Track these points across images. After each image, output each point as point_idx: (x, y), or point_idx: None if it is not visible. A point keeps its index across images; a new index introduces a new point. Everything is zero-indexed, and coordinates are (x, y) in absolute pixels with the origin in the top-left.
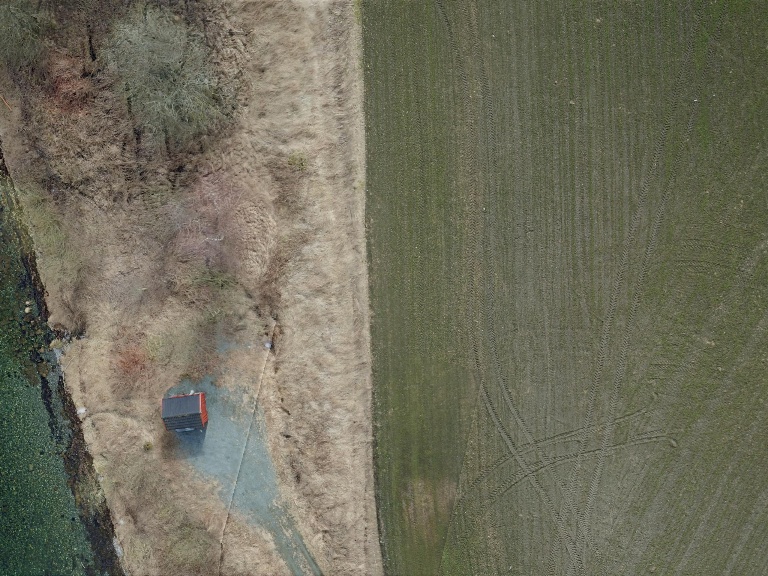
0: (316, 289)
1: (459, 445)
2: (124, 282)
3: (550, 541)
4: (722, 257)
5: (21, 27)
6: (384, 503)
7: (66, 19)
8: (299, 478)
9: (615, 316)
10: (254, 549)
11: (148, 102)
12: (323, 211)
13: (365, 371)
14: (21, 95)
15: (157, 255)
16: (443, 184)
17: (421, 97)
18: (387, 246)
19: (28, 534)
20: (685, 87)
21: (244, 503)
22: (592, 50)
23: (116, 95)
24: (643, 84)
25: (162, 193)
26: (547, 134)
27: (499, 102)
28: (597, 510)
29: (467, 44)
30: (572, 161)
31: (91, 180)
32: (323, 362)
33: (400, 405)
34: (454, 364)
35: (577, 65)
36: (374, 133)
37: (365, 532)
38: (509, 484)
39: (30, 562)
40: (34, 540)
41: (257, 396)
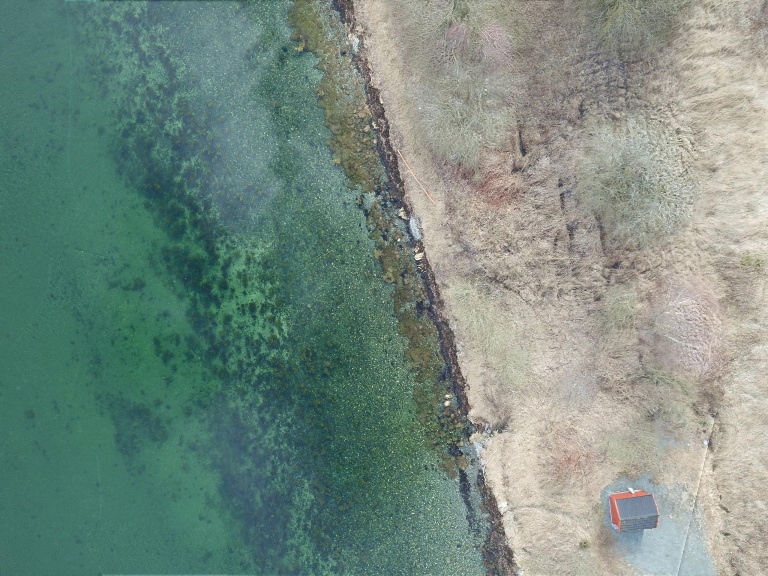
0: None
1: None
2: (552, 377)
3: None
4: None
5: (451, 122)
6: None
7: (495, 114)
8: None
9: None
10: None
11: (645, 212)
12: None
13: None
14: (445, 189)
15: (588, 351)
16: None
17: None
18: None
19: None
20: None
21: None
22: None
23: (549, 191)
24: None
25: (596, 289)
26: None
27: None
28: None
29: None
30: None
31: (518, 275)
32: None
33: None
34: None
35: None
36: None
37: None
38: None
39: None
40: None
41: (696, 494)
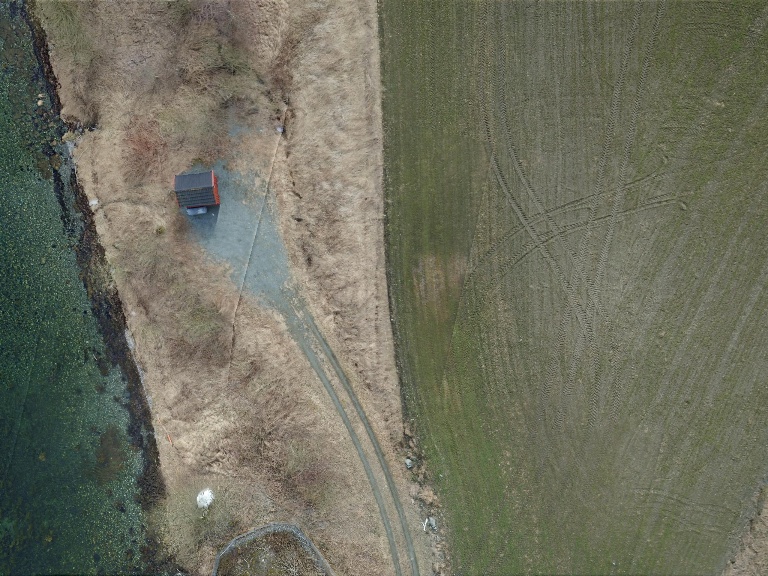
0: (328, 67)
1: (470, 219)
2: (136, 71)
3: (560, 311)
4: (732, 18)
5: None
6: (395, 280)
7: None
8: (310, 261)
9: (626, 81)
10: (266, 330)
11: None
12: None
13: (376, 147)
14: None
15: (169, 43)
16: None
17: None
18: (399, 20)
19: (40, 328)
20: None
21: (256, 285)
22: None
23: None
24: None
25: None
26: None
27: None
28: (607, 277)
29: None
30: None
31: None
32: (335, 140)
33: (411, 180)
34: (465, 137)
35: None
36: None
37: (376, 310)
38: (520, 255)
39: (42, 356)
40: (46, 333)
41: (269, 179)
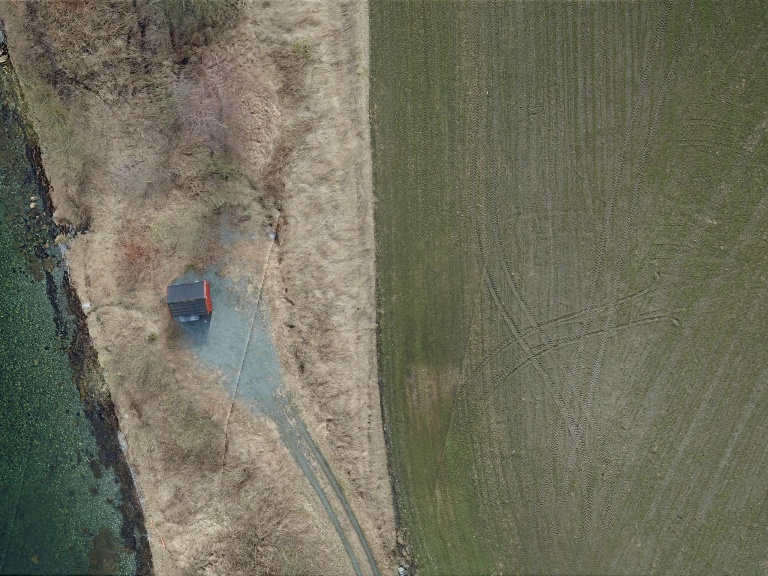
0: (320, 177)
1: (462, 330)
2: (129, 175)
3: (553, 424)
4: (724, 136)
5: None
6: (388, 390)
7: None
8: (303, 368)
9: (618, 197)
10: (258, 438)
11: None
12: (327, 98)
13: (369, 258)
14: None
15: (162, 148)
16: (446, 69)
17: None
18: (391, 132)
19: (33, 429)
20: None
21: (248, 392)
22: None
23: None
24: None
25: (167, 85)
26: (550, 16)
27: None
28: (600, 391)
29: None
30: (575, 43)
31: (96, 74)
32: (327, 250)
33: (404, 291)
34: (457, 249)
35: None
36: (378, 19)
37: (369, 419)
38: (512, 368)
39: (35, 457)
40: (39, 435)
41: (261, 286)
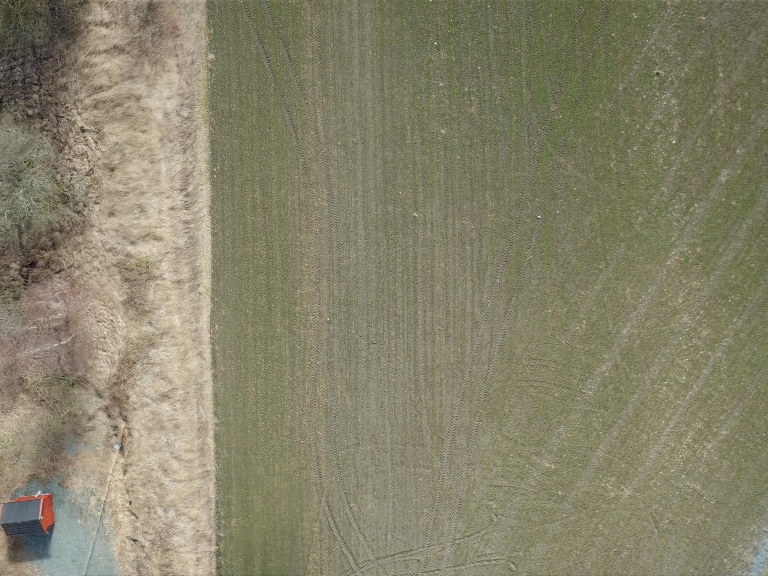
0: (162, 394)
1: (301, 558)
2: None
3: None
4: (563, 378)
5: None
6: None
7: None
8: None
9: (456, 434)
10: None
11: None
12: (168, 315)
13: (209, 479)
14: None
15: (9, 351)
16: (288, 292)
17: (267, 203)
18: (231, 353)
19: None
20: (529, 203)
21: None
22: (436, 162)
23: None
24: (487, 198)
25: (14, 289)
26: (391, 246)
27: (344, 211)
28: None
29: (313, 151)
30: (415, 274)
31: None
32: (168, 468)
33: (243, 515)
34: (297, 476)
35: (421, 176)
36: (220, 238)
37: None
38: None
39: None
40: None
41: (104, 499)
